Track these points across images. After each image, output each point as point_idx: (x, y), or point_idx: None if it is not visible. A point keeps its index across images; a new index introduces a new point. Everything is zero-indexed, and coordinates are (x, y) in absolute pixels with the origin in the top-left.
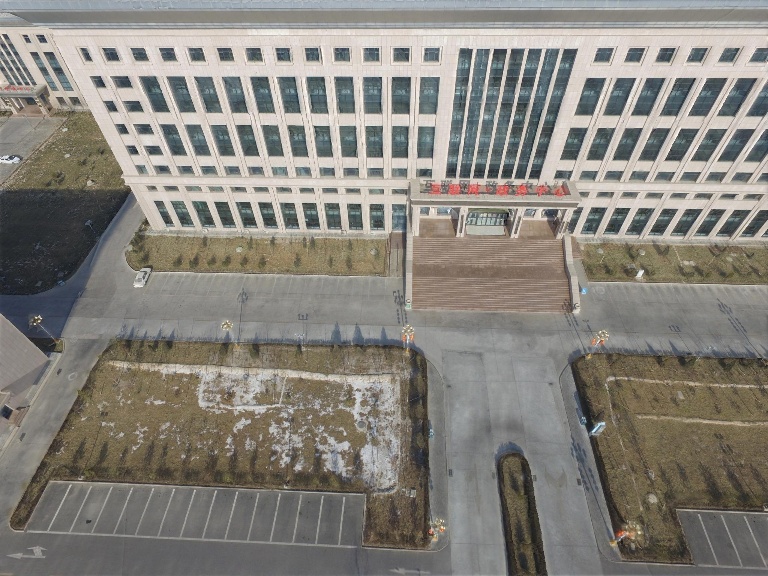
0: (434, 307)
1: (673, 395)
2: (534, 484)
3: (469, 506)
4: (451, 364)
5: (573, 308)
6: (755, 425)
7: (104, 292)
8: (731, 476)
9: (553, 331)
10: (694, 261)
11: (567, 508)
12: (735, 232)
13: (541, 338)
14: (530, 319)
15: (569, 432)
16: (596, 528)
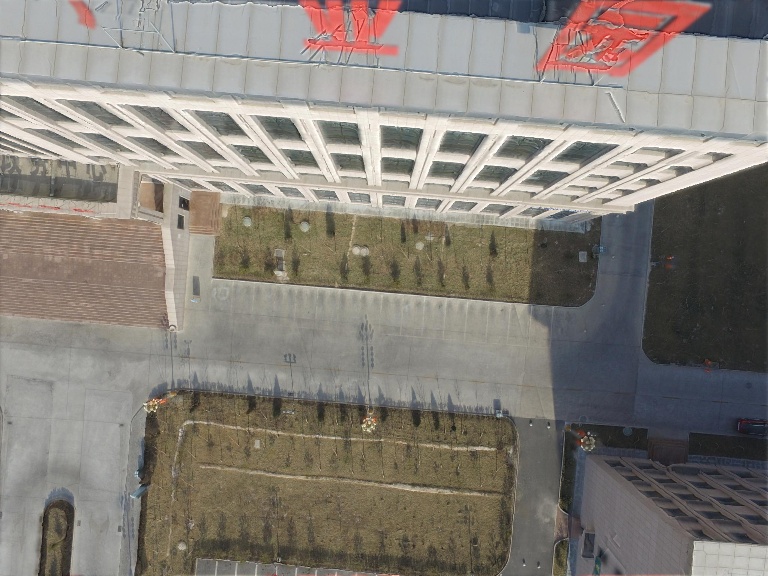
0: (2, 313)
1: (249, 444)
2: (76, 529)
3: (13, 545)
4: (15, 395)
5: (169, 329)
6: (318, 480)
7: None
8: (267, 527)
9: (143, 355)
10: (369, 248)
11: (101, 551)
12: (437, 209)
13: (126, 365)
14: (120, 336)
15: (125, 480)
16: (121, 569)
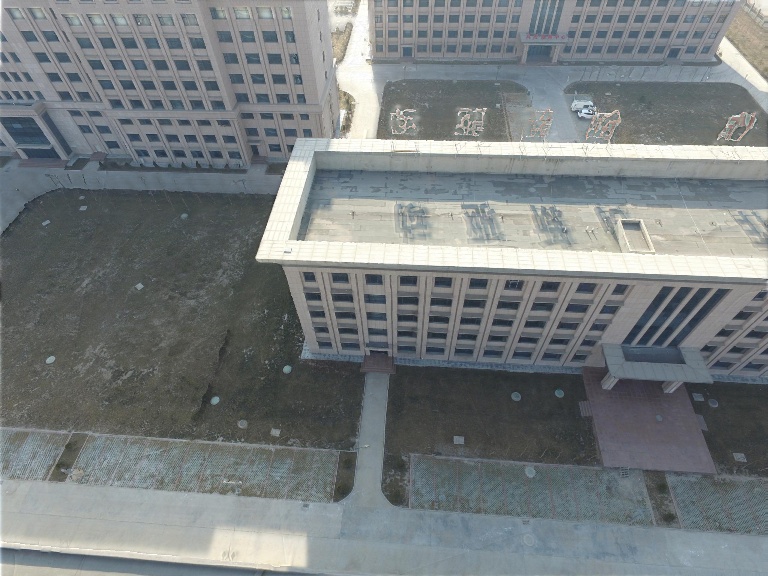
0: None
1: None
2: None
3: None
4: None
5: None
6: None
7: (358, 81)
8: None
9: None
10: None
11: None
12: None
13: None
14: None
15: None
16: None
